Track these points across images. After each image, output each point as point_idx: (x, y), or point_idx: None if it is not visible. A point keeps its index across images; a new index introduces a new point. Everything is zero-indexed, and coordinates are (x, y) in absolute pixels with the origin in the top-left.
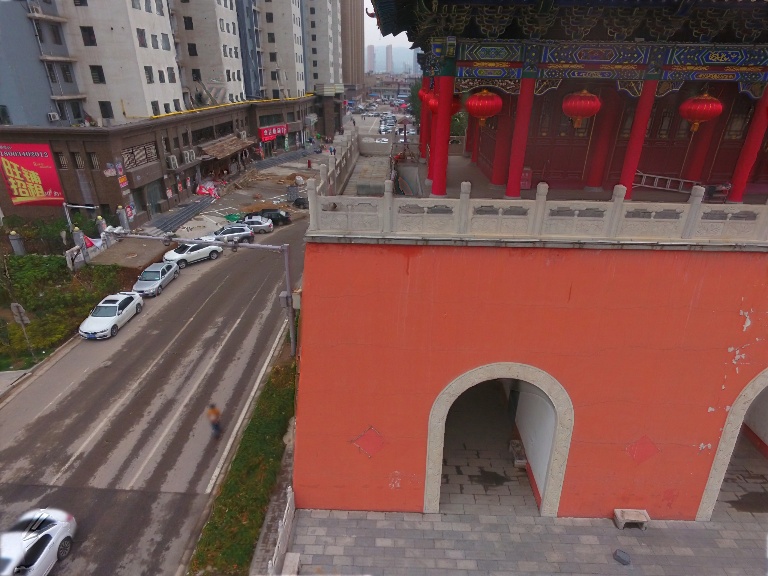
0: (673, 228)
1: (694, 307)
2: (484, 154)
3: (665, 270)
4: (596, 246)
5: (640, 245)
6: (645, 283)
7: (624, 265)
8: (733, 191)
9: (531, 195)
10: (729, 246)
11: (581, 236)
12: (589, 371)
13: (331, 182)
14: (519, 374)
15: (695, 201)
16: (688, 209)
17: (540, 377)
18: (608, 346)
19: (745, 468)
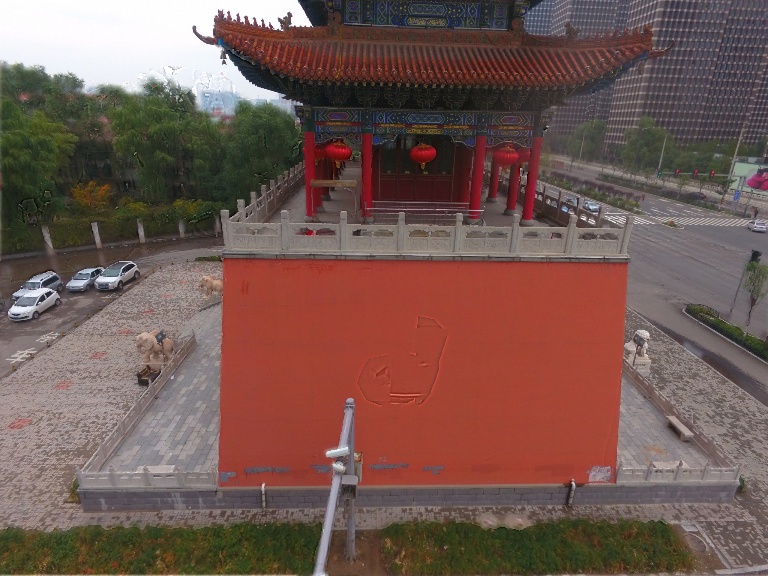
0: None
1: None
2: (402, 197)
3: None
4: None
5: None
6: None
7: None
8: None
9: None
10: None
11: None
12: None
13: (525, 238)
14: None
15: None
16: None
17: None
18: None
19: None
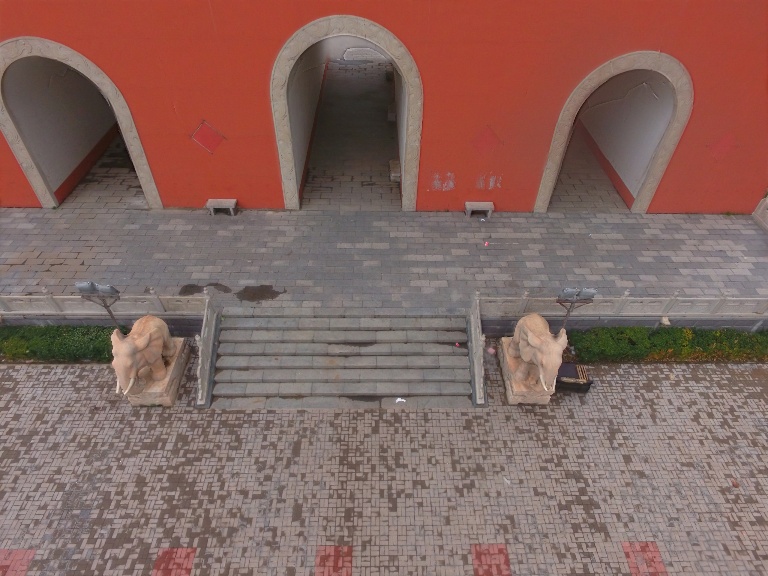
0: None
1: None
2: None
3: None
4: None
5: None
6: None
7: None
8: None
9: None
10: None
11: None
12: None
13: None
14: None
15: None
16: None
17: None
18: None
19: (346, 72)
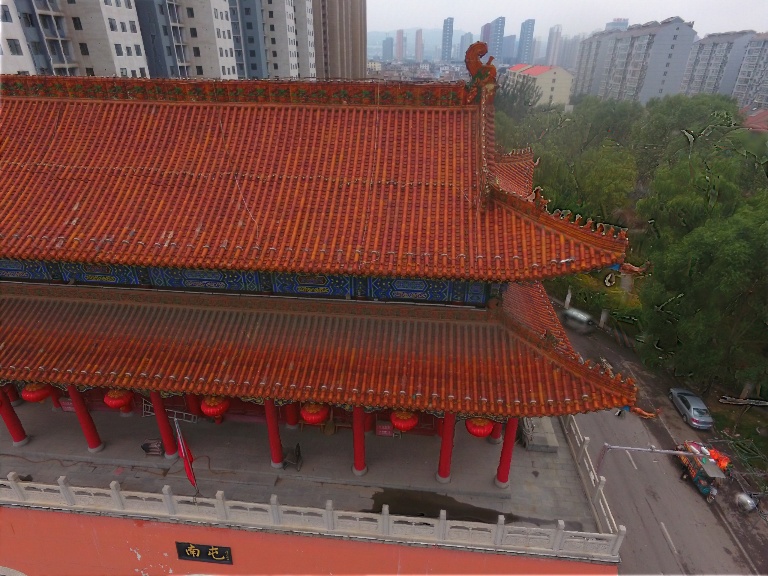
0: (60, 498)
1: (98, 544)
2: None
3: (67, 521)
4: (10, 507)
5: (39, 508)
6: (58, 528)
7: (39, 516)
8: (164, 447)
9: (63, 424)
10: (96, 513)
11: (2, 498)
12: (50, 574)
13: None
14: (5, 572)
15: (60, 486)
16: (61, 489)
17: (19, 575)
18: (55, 561)
19: None
